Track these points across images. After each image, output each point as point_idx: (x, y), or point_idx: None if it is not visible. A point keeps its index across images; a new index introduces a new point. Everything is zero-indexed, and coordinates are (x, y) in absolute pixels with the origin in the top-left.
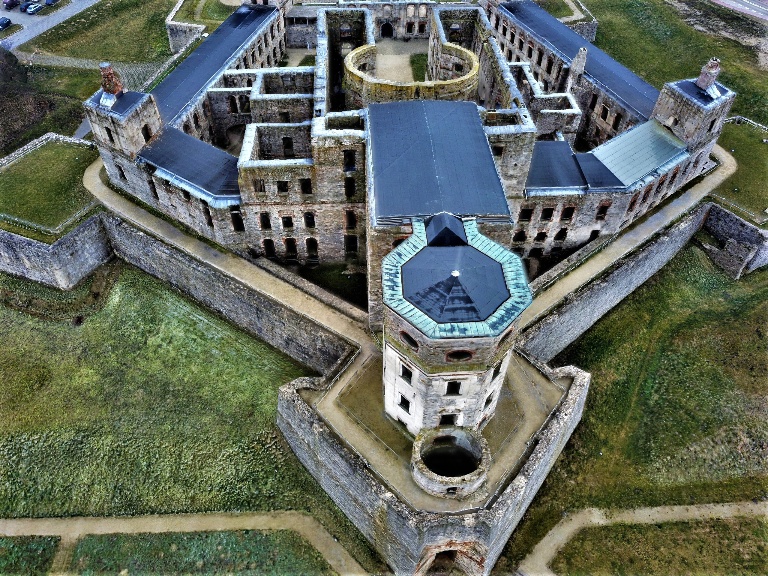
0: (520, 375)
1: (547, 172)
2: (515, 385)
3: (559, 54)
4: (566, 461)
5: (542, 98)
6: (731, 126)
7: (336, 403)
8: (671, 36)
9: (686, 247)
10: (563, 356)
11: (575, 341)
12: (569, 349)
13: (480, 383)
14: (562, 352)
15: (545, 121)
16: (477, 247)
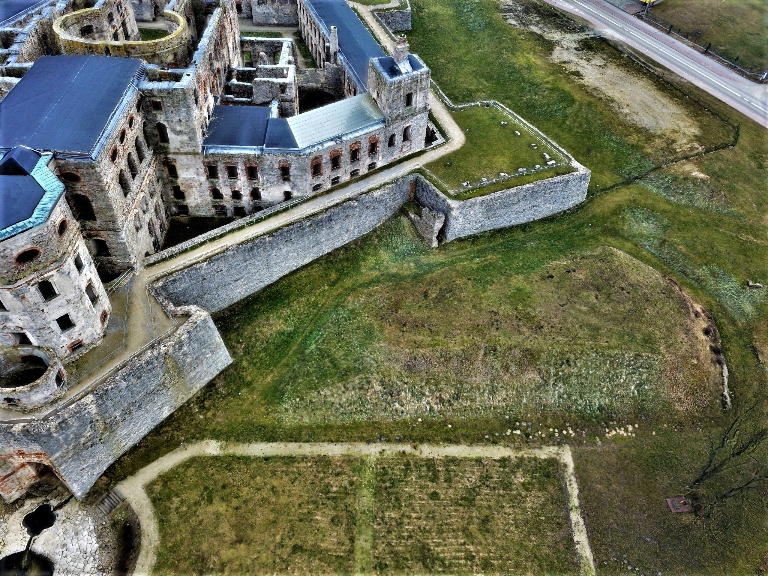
0: (144, 311)
1: (234, 133)
2: (135, 320)
3: (328, 33)
4: (201, 398)
5: (266, 68)
6: (479, 108)
7: None
8: (483, 28)
9: (396, 216)
10: (238, 306)
11: (255, 293)
12: (246, 300)
13: (19, 299)
14: (239, 302)
15: (261, 89)
16: (36, 177)
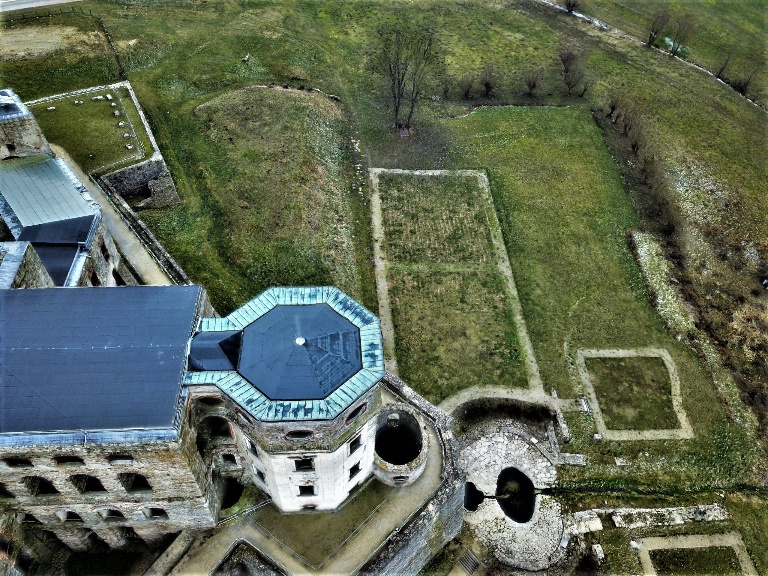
0: None
1: None
2: None
3: None
4: None
5: None
6: None
7: (317, 572)
8: None
9: None
10: None
11: None
12: None
13: None
14: None
15: None
16: (248, 323)
